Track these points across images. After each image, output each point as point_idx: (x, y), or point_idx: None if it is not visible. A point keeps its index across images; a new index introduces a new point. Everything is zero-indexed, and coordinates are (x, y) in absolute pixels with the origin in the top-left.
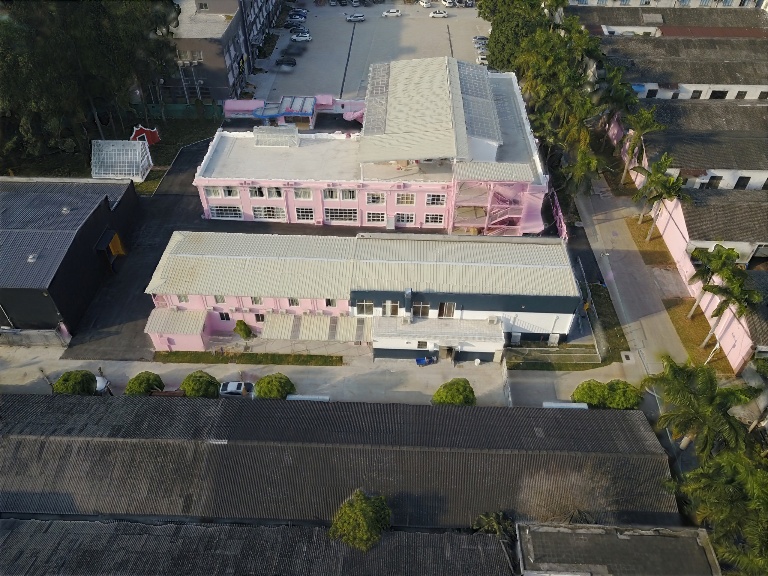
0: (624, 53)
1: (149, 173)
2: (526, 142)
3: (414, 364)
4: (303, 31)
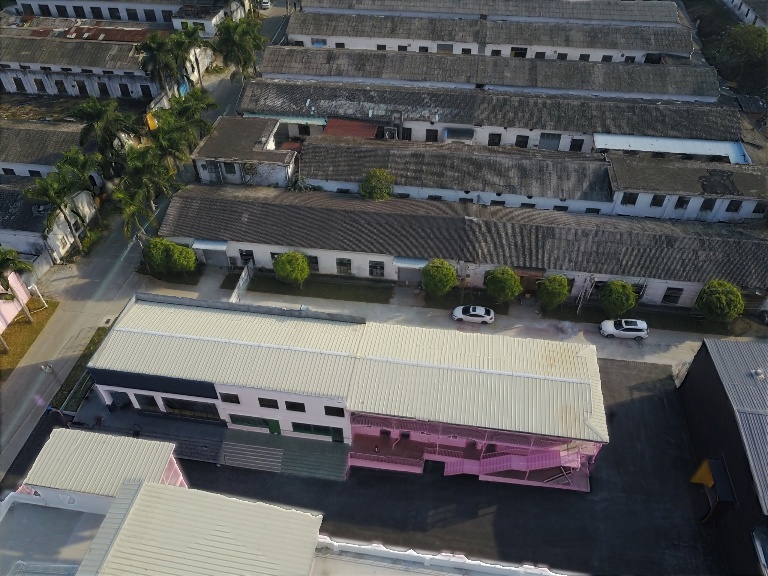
0: None
1: None
2: None
3: None
4: None
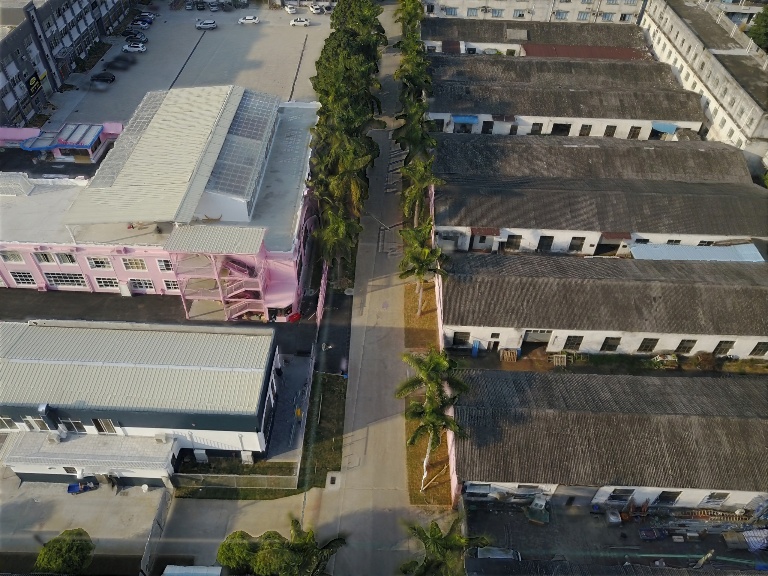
0: (470, 76)
1: None
2: (298, 192)
3: (66, 491)
4: (140, 40)
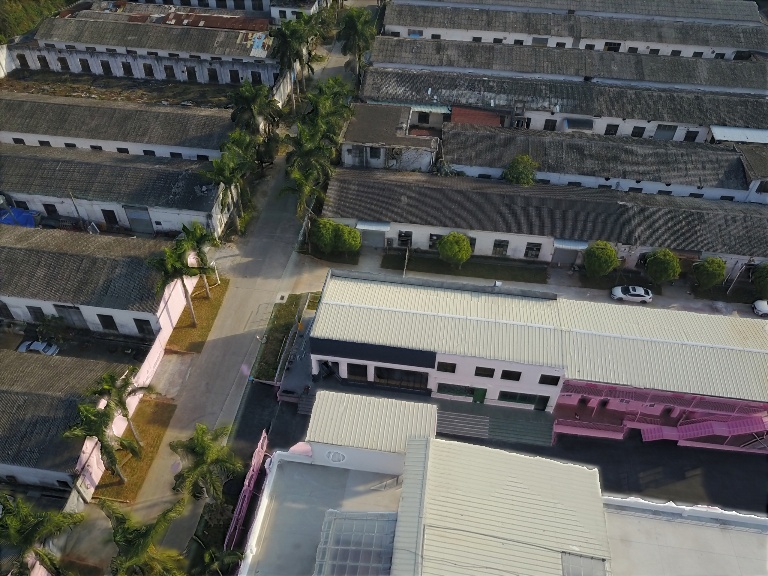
0: None
1: None
2: None
3: None
4: None
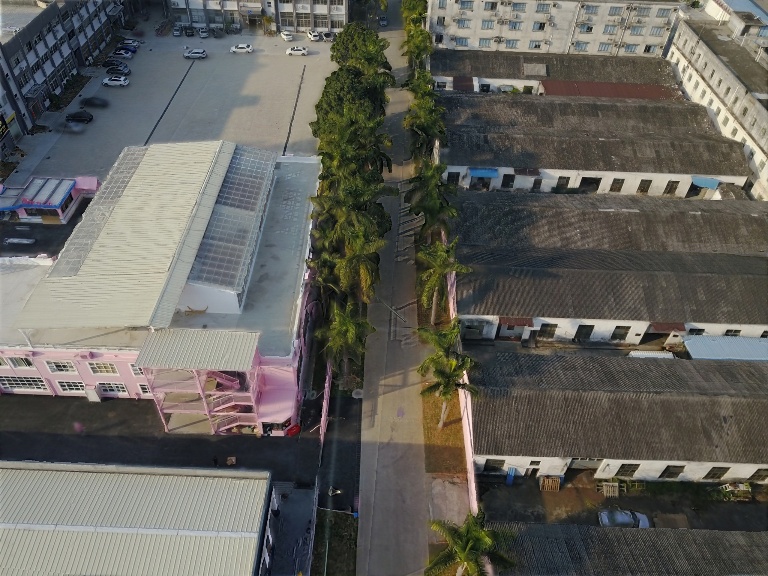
0: (486, 120)
1: None
2: (298, 273)
3: None
4: (122, 72)
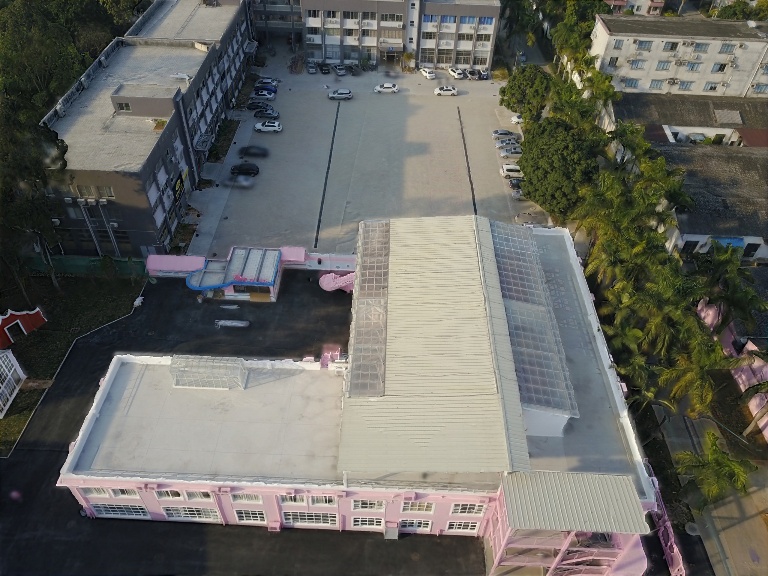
0: (704, 177)
1: (16, 397)
2: (604, 381)
3: None
4: (271, 116)
